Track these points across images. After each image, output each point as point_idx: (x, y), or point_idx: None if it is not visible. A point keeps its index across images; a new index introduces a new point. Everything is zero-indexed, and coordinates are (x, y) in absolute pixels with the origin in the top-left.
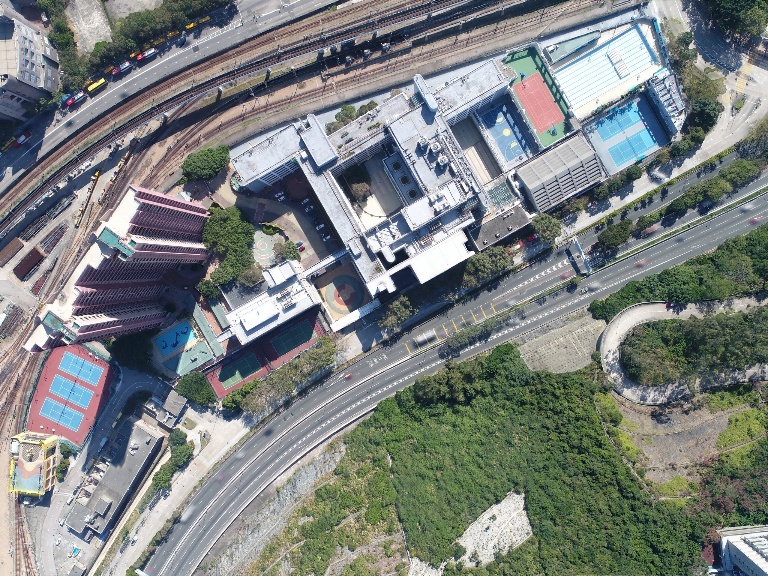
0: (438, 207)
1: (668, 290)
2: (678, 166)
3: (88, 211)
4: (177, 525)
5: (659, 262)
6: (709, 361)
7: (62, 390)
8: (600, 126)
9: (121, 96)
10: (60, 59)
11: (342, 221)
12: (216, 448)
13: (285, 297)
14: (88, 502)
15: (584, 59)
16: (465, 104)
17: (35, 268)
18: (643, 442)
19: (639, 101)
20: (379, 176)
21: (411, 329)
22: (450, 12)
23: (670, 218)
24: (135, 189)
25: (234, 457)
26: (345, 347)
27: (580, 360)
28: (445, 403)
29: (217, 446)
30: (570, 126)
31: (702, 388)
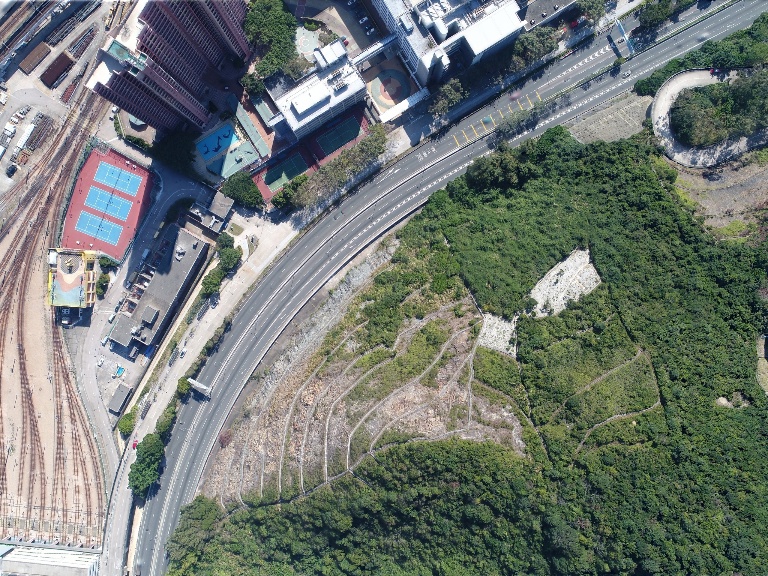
0: None
1: (712, 58)
2: None
3: (119, 12)
4: (228, 334)
5: (697, 42)
6: (757, 115)
7: (98, 202)
8: None
9: None
10: None
11: None
12: (265, 253)
13: (336, 79)
14: (133, 313)
15: None
16: None
17: (64, 74)
18: (698, 196)
19: None
20: None
21: (459, 120)
22: None
23: (706, 0)
24: None
25: (284, 260)
26: (393, 142)
27: (631, 129)
28: (498, 188)
29: (266, 251)
30: None
31: (749, 147)
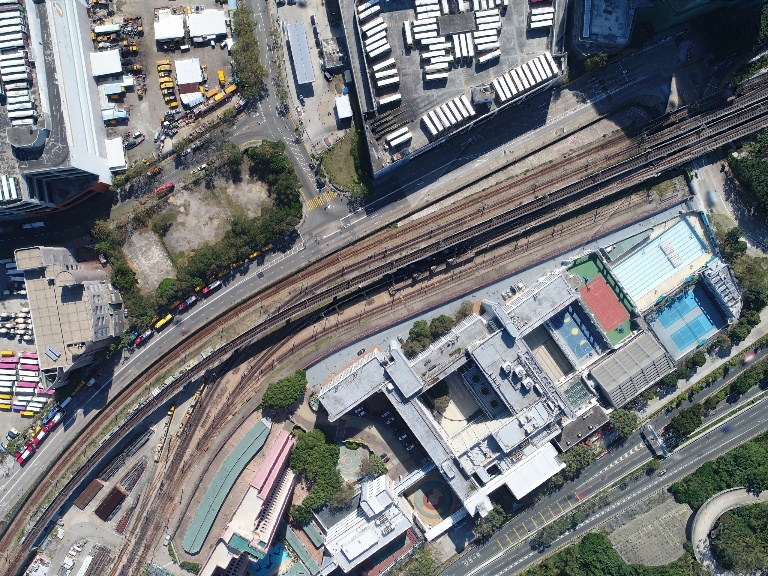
0: (529, 429)
1: (746, 475)
2: (736, 345)
3: (167, 445)
4: None
5: (729, 438)
6: None
7: None
8: (660, 315)
9: (189, 328)
10: (126, 303)
11: (433, 445)
12: None
13: (383, 522)
14: None
15: (639, 252)
16: (539, 320)
17: (118, 507)
18: None
19: (694, 288)
20: (455, 382)
21: (501, 526)
22: (509, 222)
23: (734, 395)
24: (257, 488)
25: None
26: (439, 550)
27: (673, 550)
28: None
29: None
30: (636, 324)
31: None
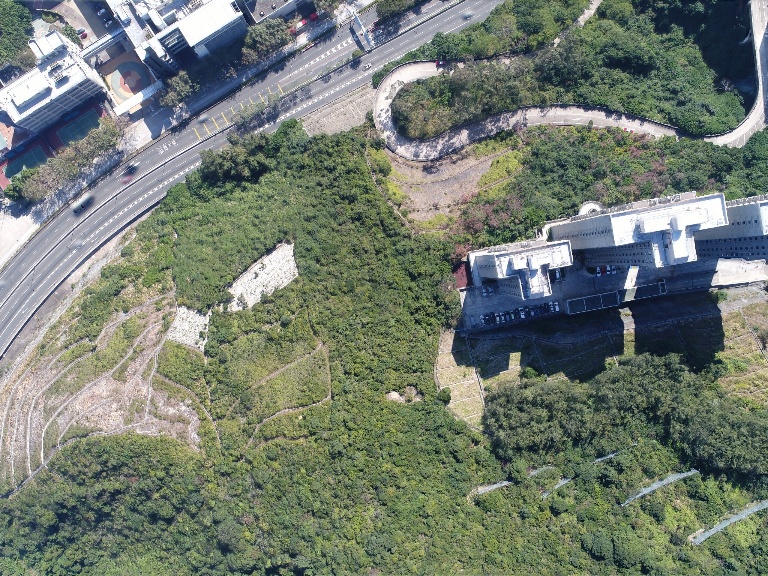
0: None
1: None
2: None
3: None
4: None
5: None
6: None
7: None
8: None
9: None
10: None
11: None
12: (6, 246)
13: (56, 71)
14: None
15: None
16: None
17: None
18: (411, 189)
19: None
20: None
21: (199, 113)
22: None
23: None
24: None
25: (24, 253)
26: (134, 135)
27: (355, 122)
28: (233, 182)
29: (6, 244)
30: None
31: (470, 140)
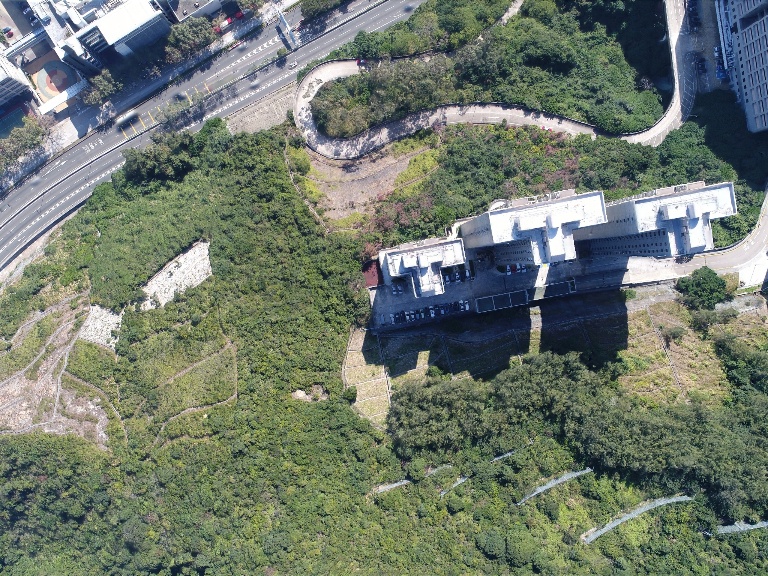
0: None
1: None
2: None
3: None
4: None
5: None
6: (390, 106)
7: None
8: None
9: None
10: None
11: None
12: None
13: None
14: None
15: None
16: None
17: None
18: (329, 188)
19: None
20: None
21: (125, 112)
22: None
23: None
24: None
25: None
26: (60, 134)
27: (277, 120)
28: (158, 180)
29: None
30: None
31: (390, 138)
